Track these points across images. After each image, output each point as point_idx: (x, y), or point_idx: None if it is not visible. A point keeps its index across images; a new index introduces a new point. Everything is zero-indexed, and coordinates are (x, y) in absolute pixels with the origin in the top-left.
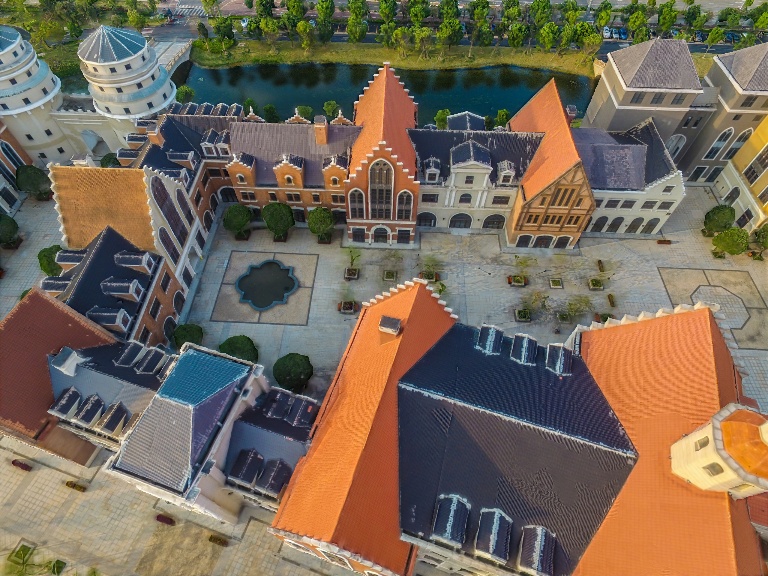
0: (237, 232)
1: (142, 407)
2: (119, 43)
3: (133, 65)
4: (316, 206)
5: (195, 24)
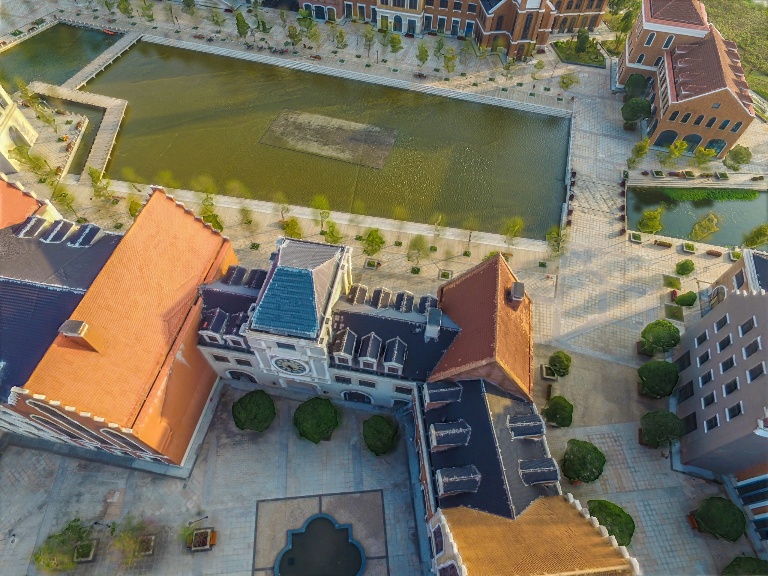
0: None
1: (356, 306)
2: None
3: None
4: None
5: None
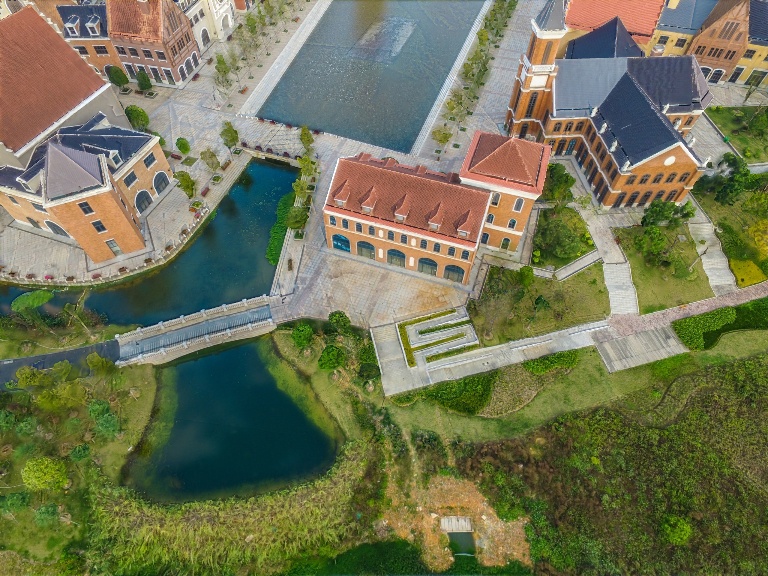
0: None
1: None
2: None
3: None
4: None
5: None
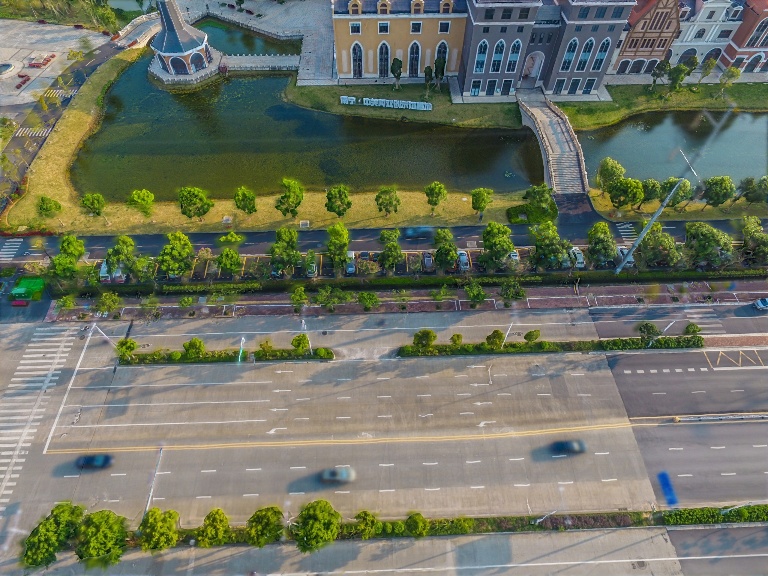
0: None
1: None
2: None
3: None
4: None
5: None
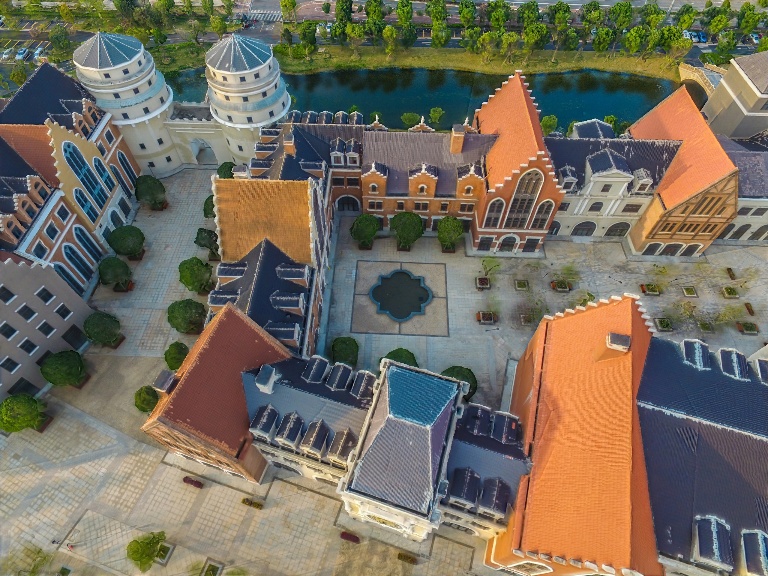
0: (361, 241)
1: (346, 425)
2: (249, 52)
3: (261, 74)
4: (441, 215)
5: (271, 29)
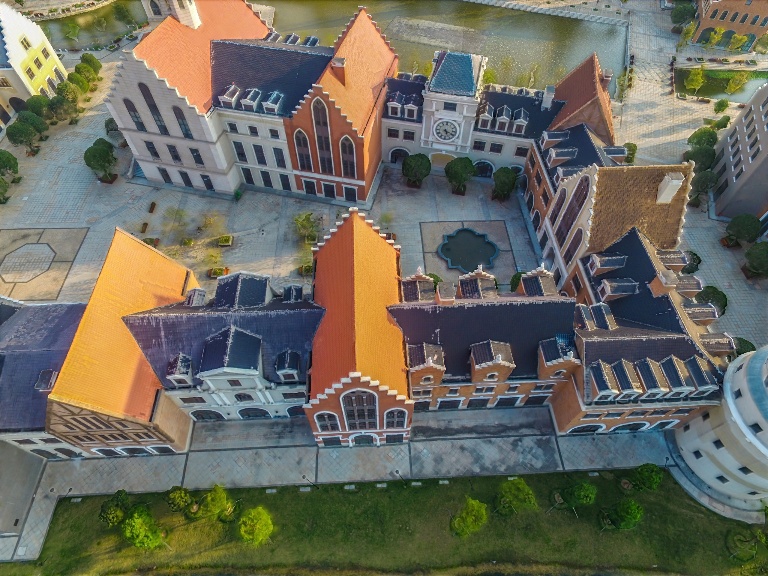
0: None
1: None
2: None
3: None
4: None
5: None
